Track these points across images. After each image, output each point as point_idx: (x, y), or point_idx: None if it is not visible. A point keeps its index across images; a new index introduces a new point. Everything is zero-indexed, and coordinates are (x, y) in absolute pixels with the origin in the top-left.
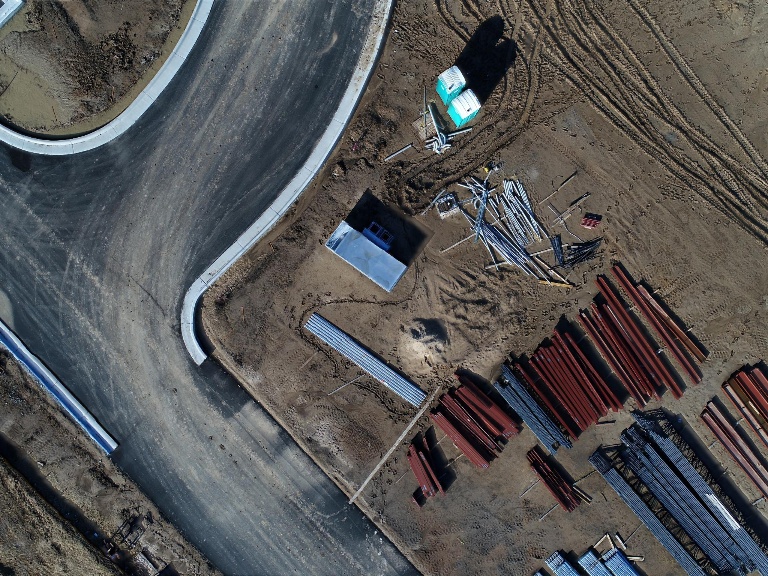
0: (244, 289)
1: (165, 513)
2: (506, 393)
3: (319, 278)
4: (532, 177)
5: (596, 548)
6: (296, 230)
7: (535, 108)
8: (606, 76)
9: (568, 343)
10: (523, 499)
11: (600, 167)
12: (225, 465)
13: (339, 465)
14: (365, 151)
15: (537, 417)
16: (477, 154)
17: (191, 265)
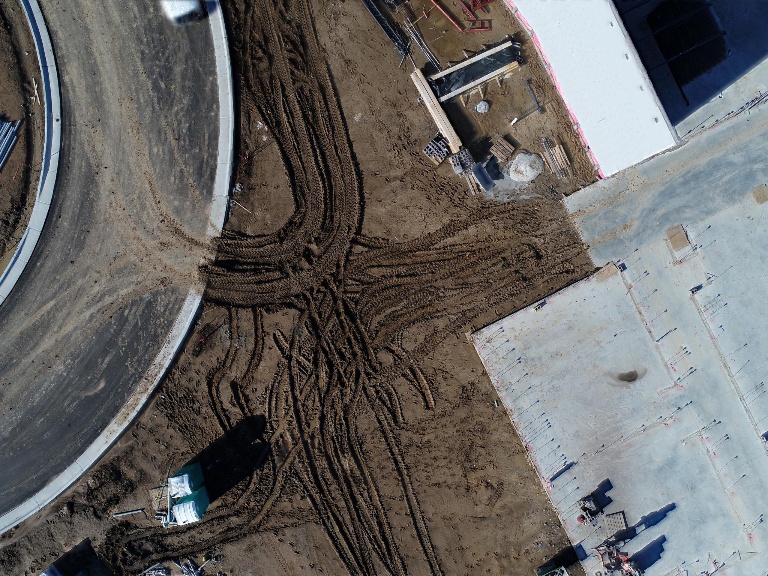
0: None
1: None
2: None
3: None
4: None
5: None
6: (7, 554)
7: (270, 514)
8: (345, 507)
9: None
10: None
11: None
12: None
13: None
14: (96, 502)
15: None
16: (201, 539)
17: None
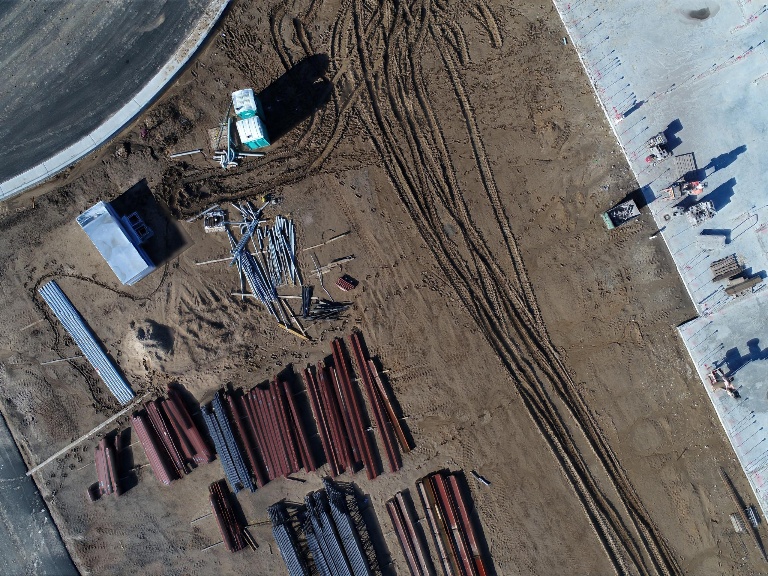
0: None
1: None
2: (208, 420)
3: (68, 249)
4: (306, 222)
5: None
6: (62, 194)
7: (331, 157)
8: (409, 150)
9: (283, 392)
10: (194, 525)
11: (373, 235)
12: None
13: (29, 435)
14: (154, 141)
15: (230, 452)
16: (261, 182)
17: None
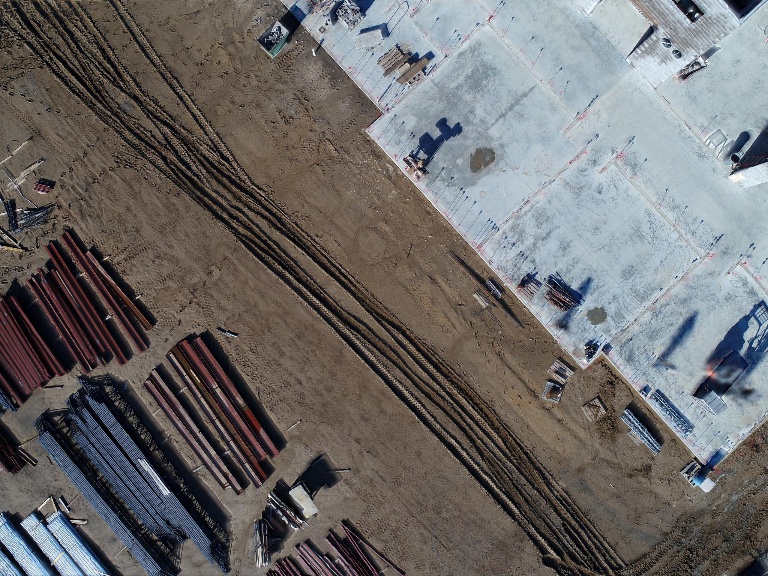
0: None
1: None
2: None
3: None
4: None
5: (41, 510)
6: None
7: None
8: (64, 43)
9: (13, 306)
10: None
11: (55, 133)
12: None
13: None
14: None
15: None
16: None
17: None
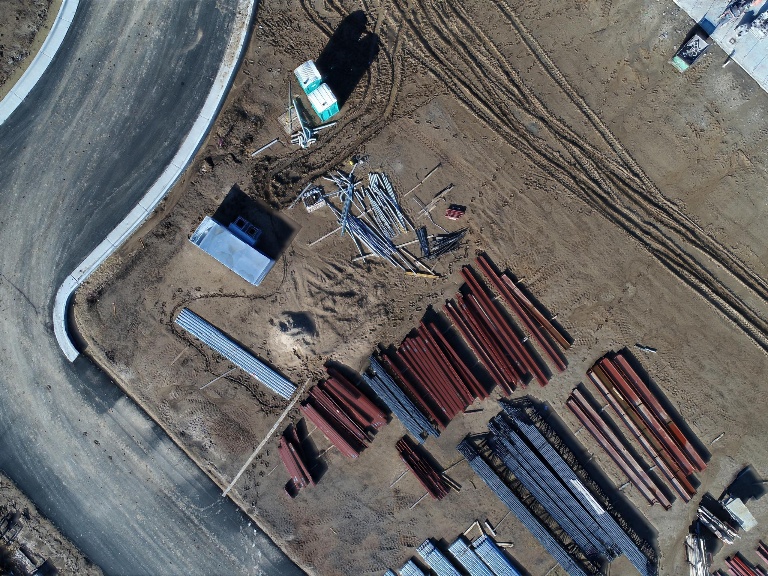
0: (115, 285)
1: (42, 509)
2: (373, 384)
3: (188, 273)
4: (397, 170)
5: (466, 535)
6: (165, 226)
7: (399, 101)
8: (468, 68)
9: (434, 333)
10: (394, 488)
11: (463, 159)
12: (100, 460)
13: (212, 458)
14: (232, 147)
15: (404, 407)
16: (342, 148)
17: (62, 263)
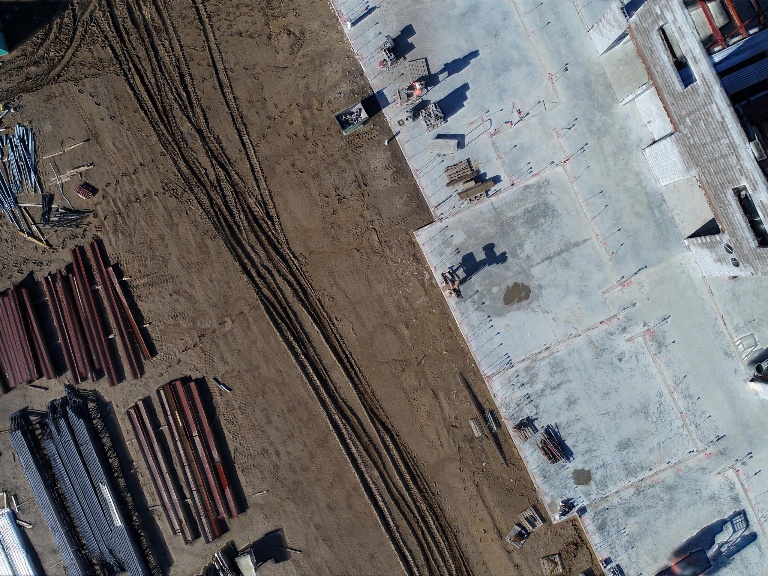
0: None
1: None
2: None
3: None
4: (45, 130)
5: None
6: None
7: (70, 65)
8: (146, 58)
9: (22, 299)
10: None
11: (112, 143)
12: None
13: None
14: None
15: None
16: (0, 90)
17: None
